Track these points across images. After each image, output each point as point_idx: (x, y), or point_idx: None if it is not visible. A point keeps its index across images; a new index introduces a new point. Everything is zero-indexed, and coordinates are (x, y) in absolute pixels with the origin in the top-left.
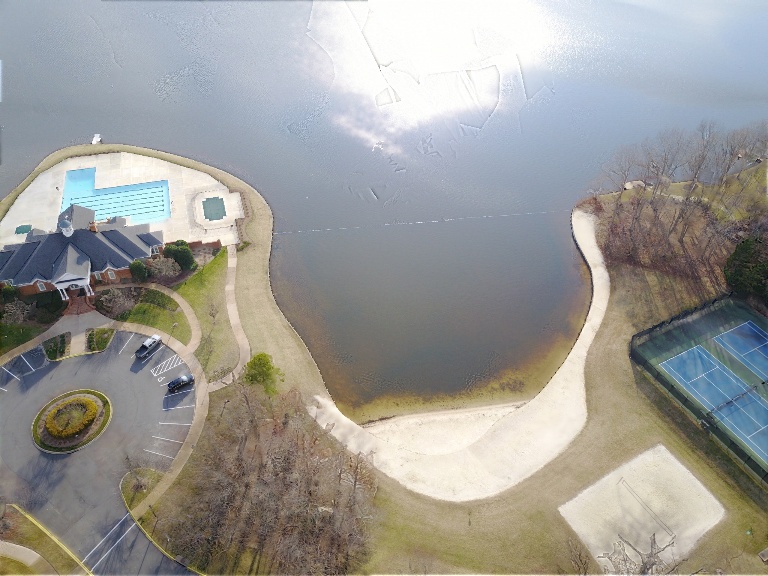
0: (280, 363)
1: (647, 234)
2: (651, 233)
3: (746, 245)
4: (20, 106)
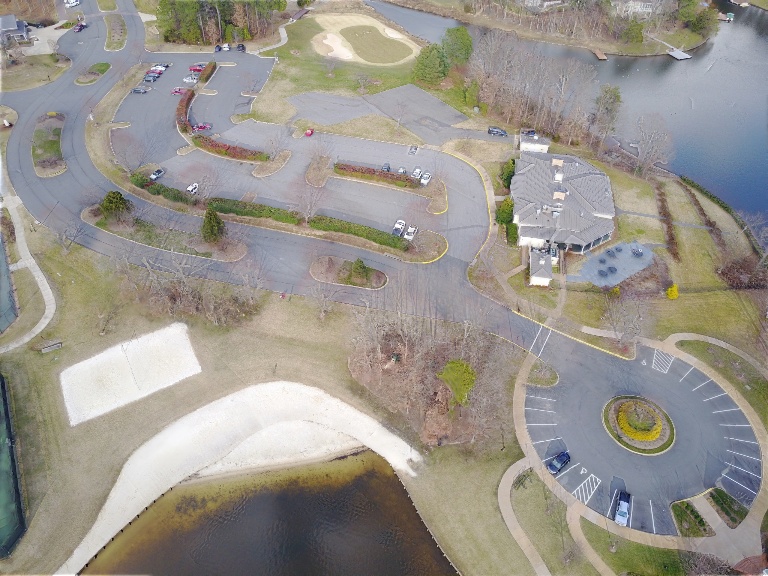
0: (464, 509)
1: None
2: None
3: None
4: None
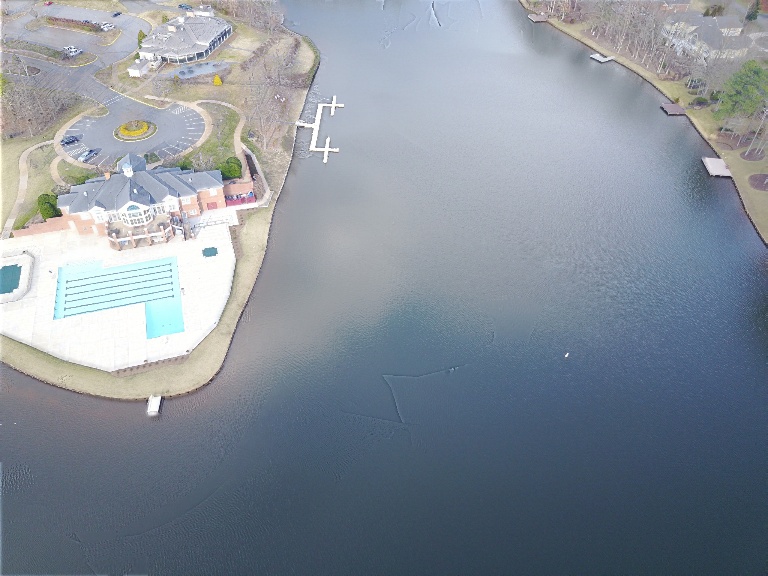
0: (3, 158)
1: None
2: None
3: None
4: (264, 408)
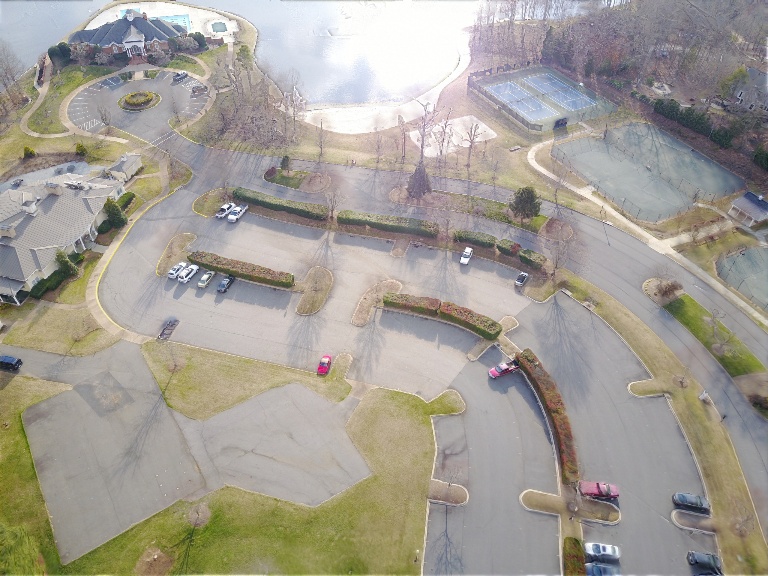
0: None
1: (502, 39)
2: (504, 39)
3: (550, 30)
4: None
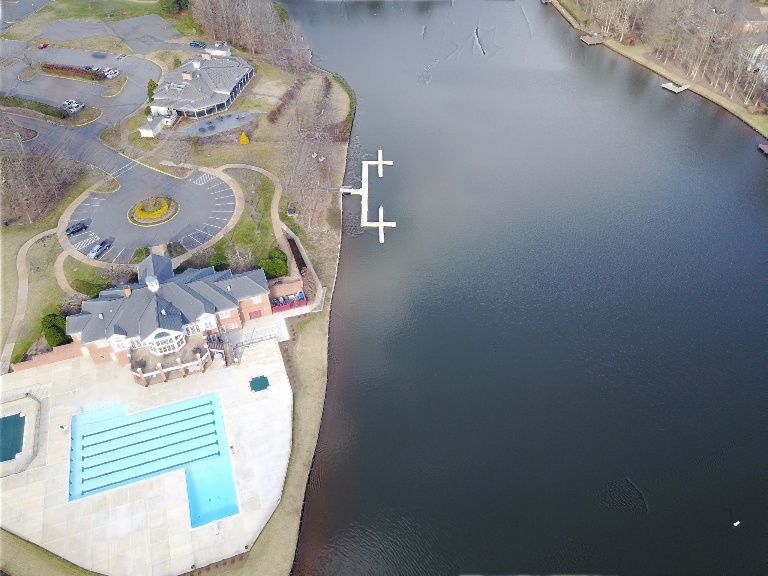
0: None
1: None
2: None
3: None
4: None
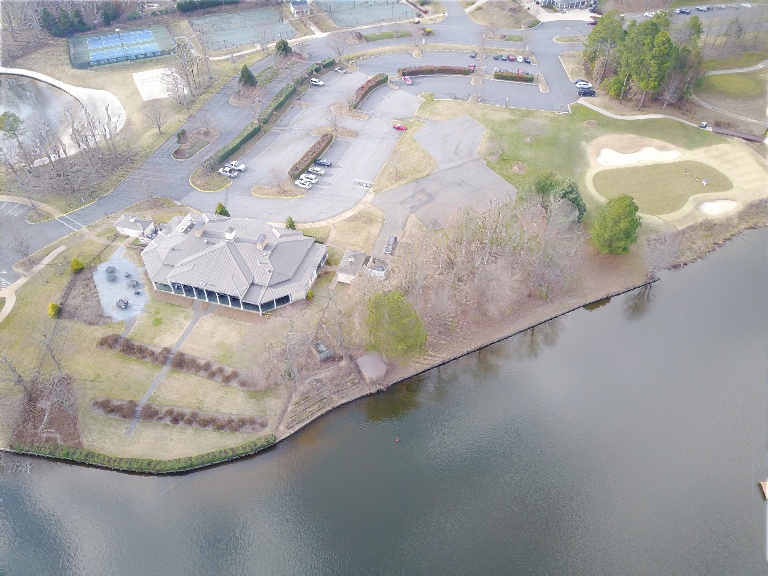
0: None
1: None
2: None
3: (46, 12)
4: None
